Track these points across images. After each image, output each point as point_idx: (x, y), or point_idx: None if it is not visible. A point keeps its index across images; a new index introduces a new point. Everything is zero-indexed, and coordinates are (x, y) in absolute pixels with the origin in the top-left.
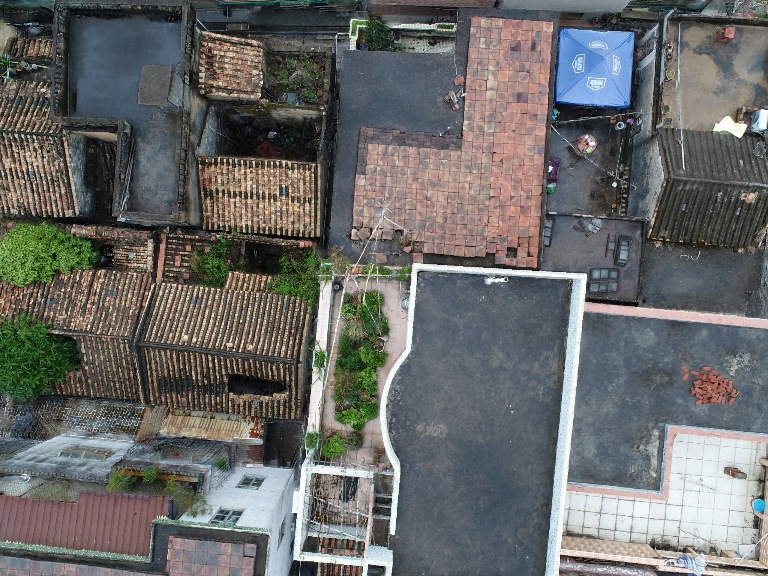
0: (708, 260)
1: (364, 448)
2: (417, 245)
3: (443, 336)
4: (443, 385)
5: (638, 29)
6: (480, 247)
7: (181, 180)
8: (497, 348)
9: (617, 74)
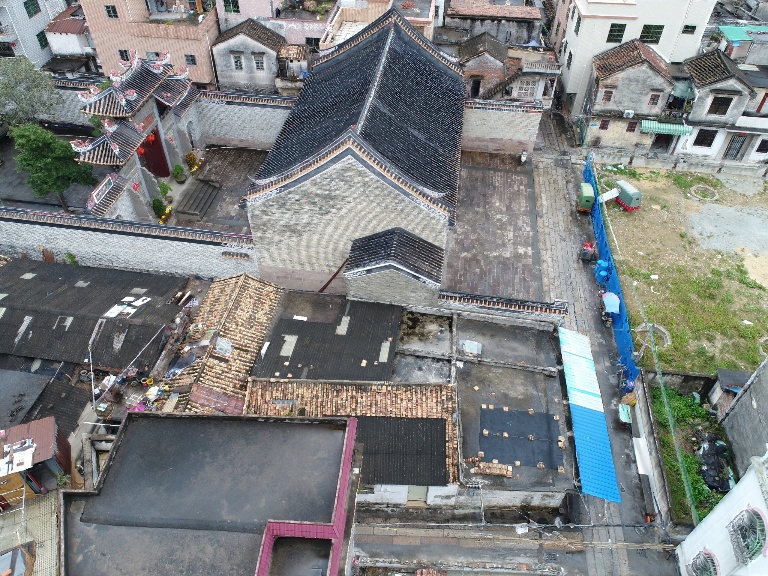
0: None
1: None
2: None
3: None
4: None
5: None
6: (454, 6)
7: None
8: None
9: None
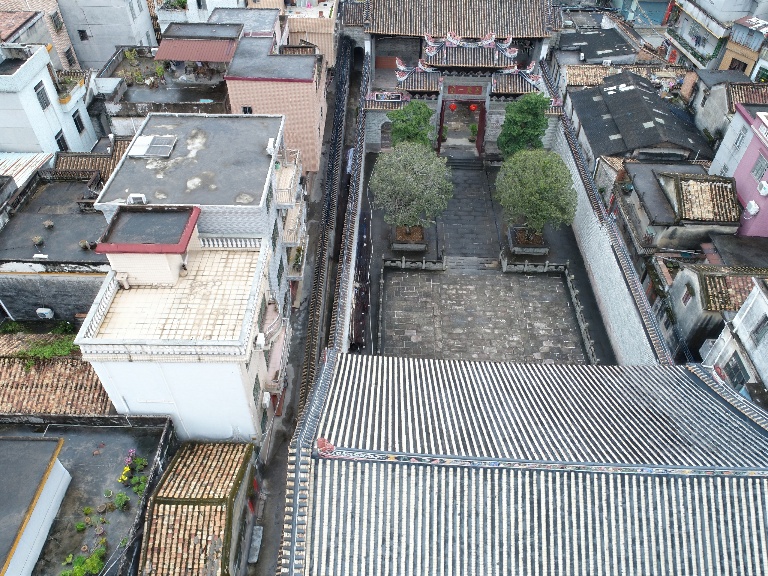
0: None
1: (186, 9)
2: None
3: None
4: None
5: None
6: None
7: None
8: None
9: None
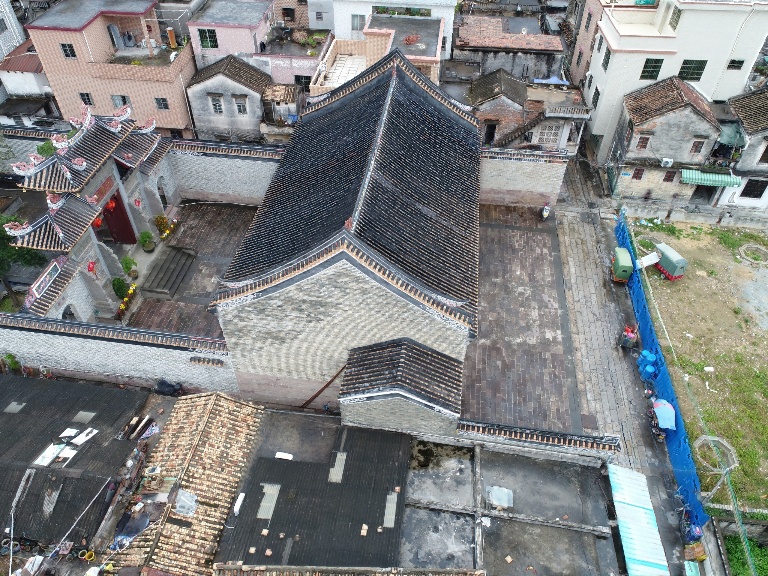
0: None
1: None
2: None
3: None
4: None
5: (595, 180)
6: None
7: (480, 6)
8: None
9: None
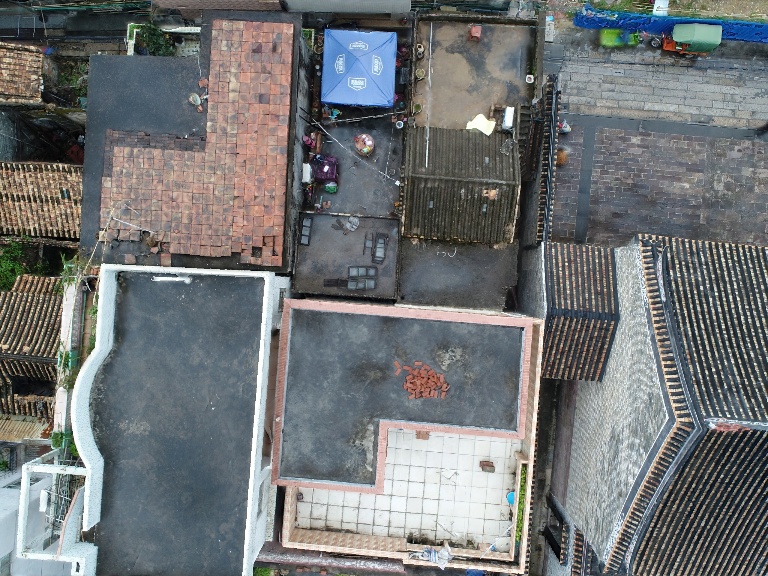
0: (465, 256)
1: None
2: (165, 246)
3: (144, 335)
4: (145, 383)
5: None
6: (225, 247)
7: None
8: (197, 346)
9: (378, 74)
